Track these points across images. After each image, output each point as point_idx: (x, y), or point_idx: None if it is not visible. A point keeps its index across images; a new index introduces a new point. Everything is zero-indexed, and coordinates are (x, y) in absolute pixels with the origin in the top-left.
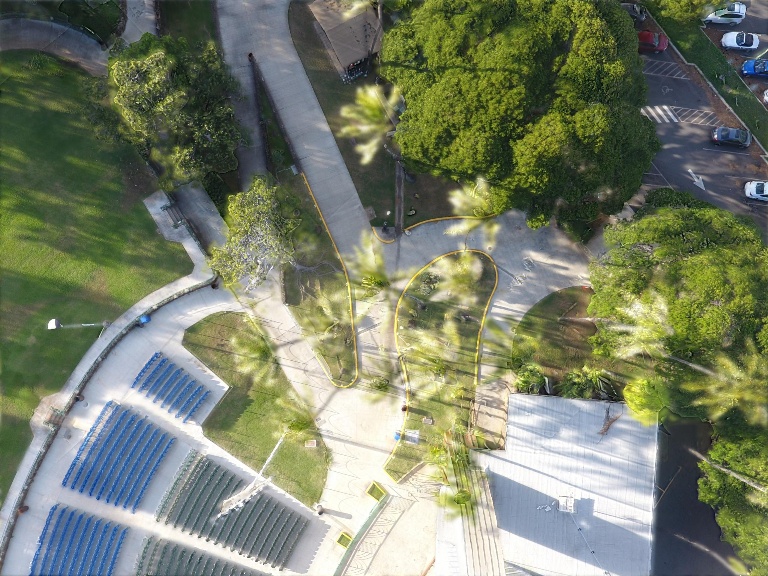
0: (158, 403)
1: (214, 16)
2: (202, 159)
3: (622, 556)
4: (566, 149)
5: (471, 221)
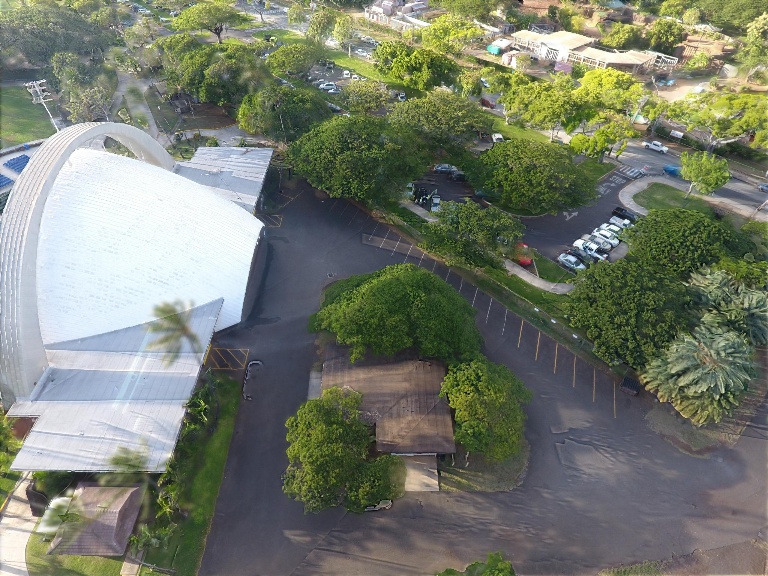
0: (14, 171)
1: (113, 91)
2: (80, 84)
3: (244, 187)
4: (223, 70)
5: (208, 130)
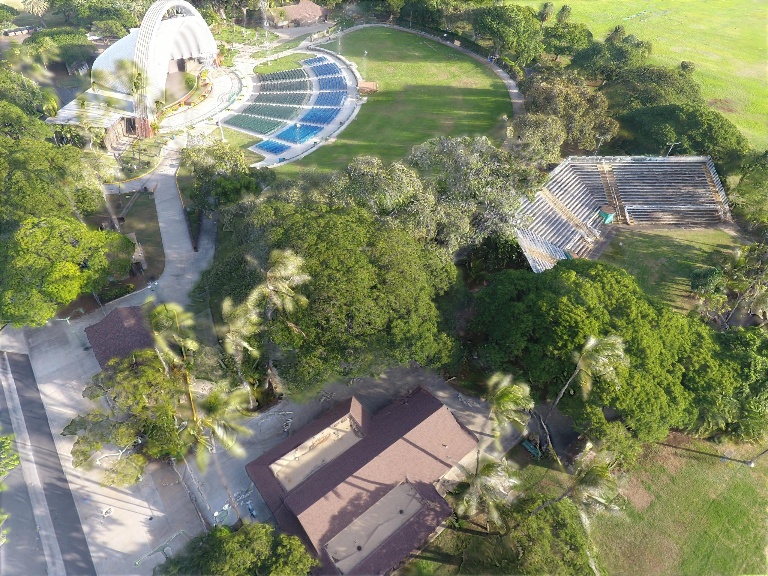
0: None
1: None
2: None
3: None
4: None
5: None
